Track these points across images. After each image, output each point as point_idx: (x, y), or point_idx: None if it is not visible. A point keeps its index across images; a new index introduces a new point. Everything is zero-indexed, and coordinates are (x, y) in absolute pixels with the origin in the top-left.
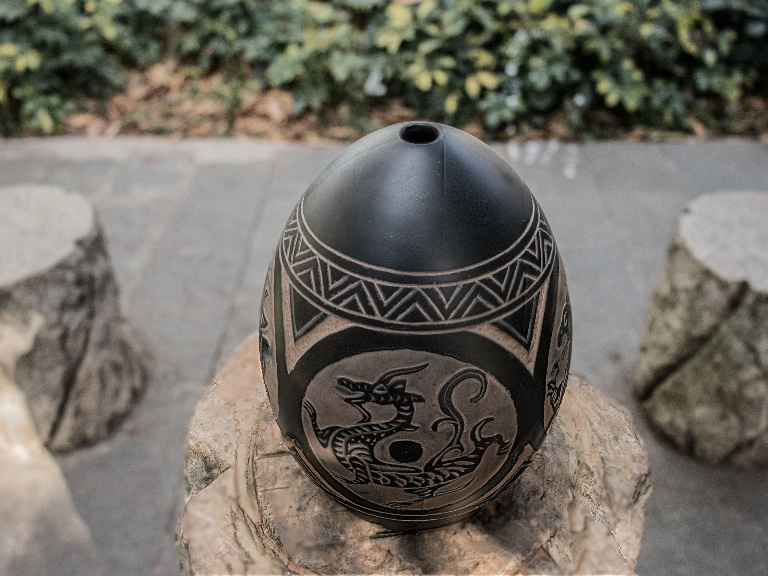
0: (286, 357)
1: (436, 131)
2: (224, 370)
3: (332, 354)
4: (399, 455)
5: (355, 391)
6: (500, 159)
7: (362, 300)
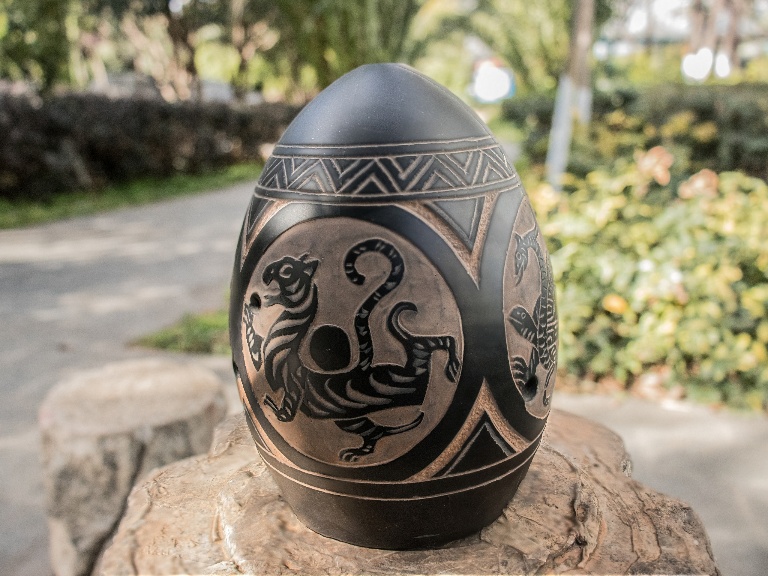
0: None
1: None
2: None
3: None
4: None
5: None
6: (380, 103)
7: None
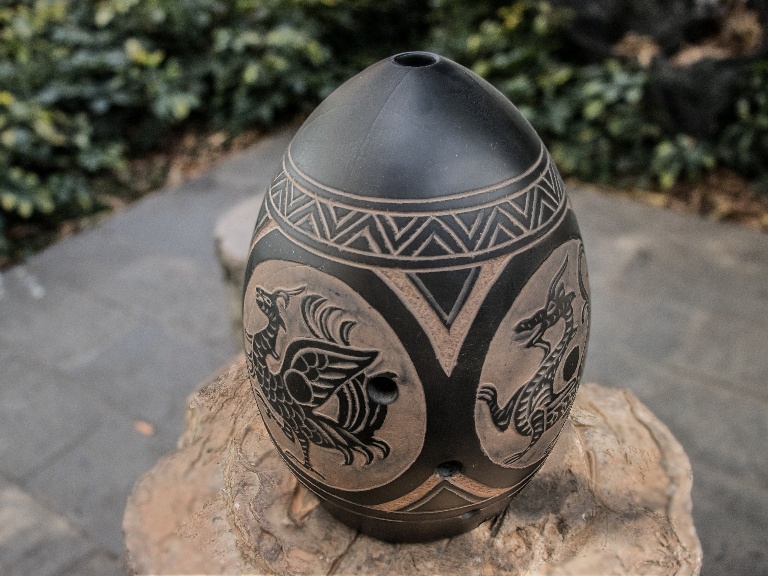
0: (439, 359)
1: (416, 56)
2: (151, 573)
3: (502, 305)
4: (568, 373)
5: (533, 328)
6: None
7: (507, 225)
